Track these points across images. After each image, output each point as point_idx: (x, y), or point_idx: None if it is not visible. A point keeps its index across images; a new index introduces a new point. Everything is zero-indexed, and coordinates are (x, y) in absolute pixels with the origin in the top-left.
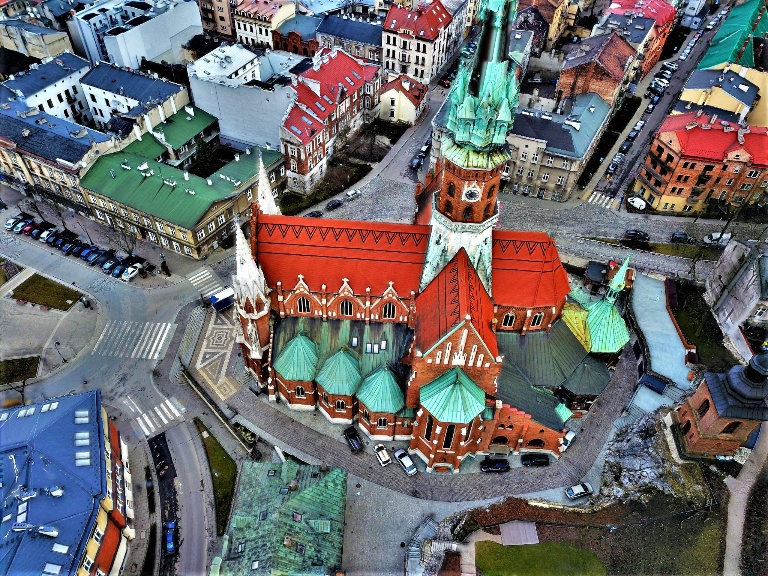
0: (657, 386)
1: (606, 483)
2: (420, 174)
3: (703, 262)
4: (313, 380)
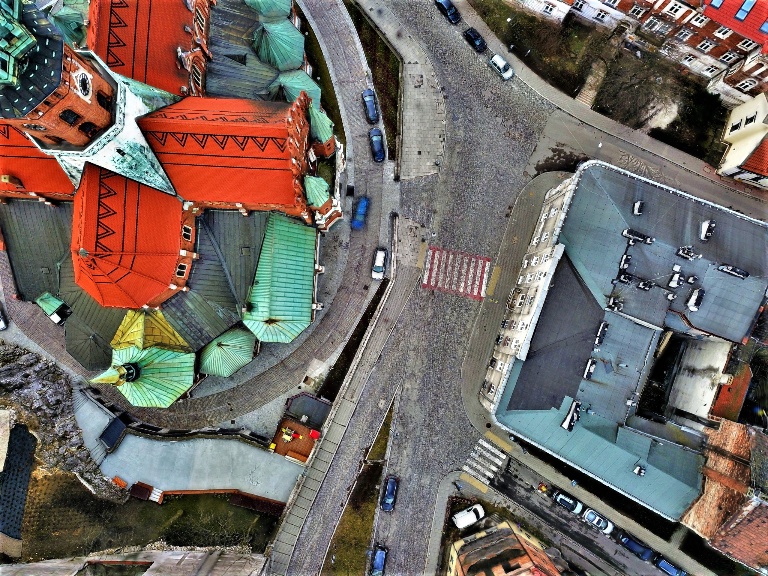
0: (110, 436)
1: (2, 345)
2: (560, 175)
3: (316, 572)
4: (64, 3)
